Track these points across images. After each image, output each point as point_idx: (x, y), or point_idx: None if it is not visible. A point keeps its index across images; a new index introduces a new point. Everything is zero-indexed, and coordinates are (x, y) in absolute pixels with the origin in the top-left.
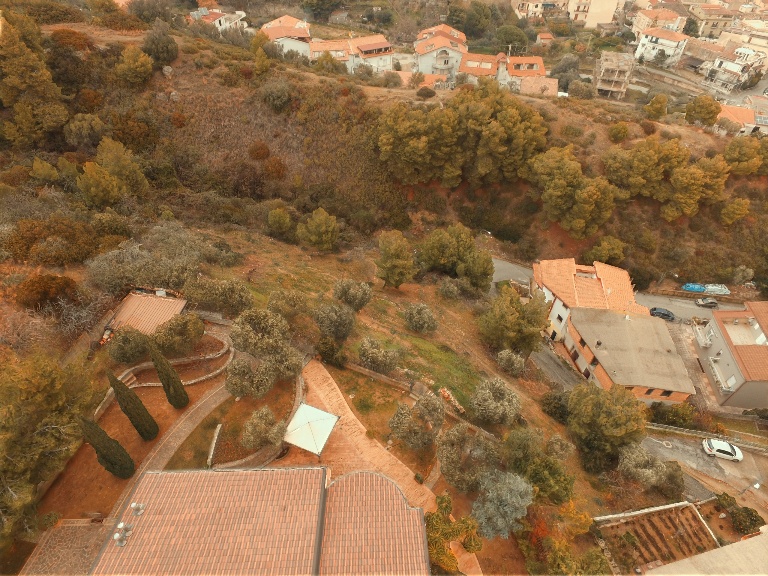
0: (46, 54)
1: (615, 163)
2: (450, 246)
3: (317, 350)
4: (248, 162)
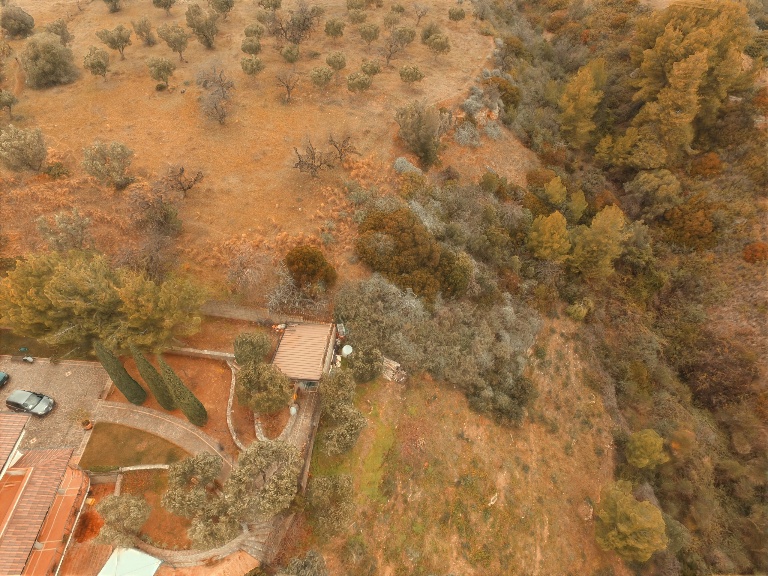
0: (732, 102)
1: None
2: None
3: None
4: (762, 365)
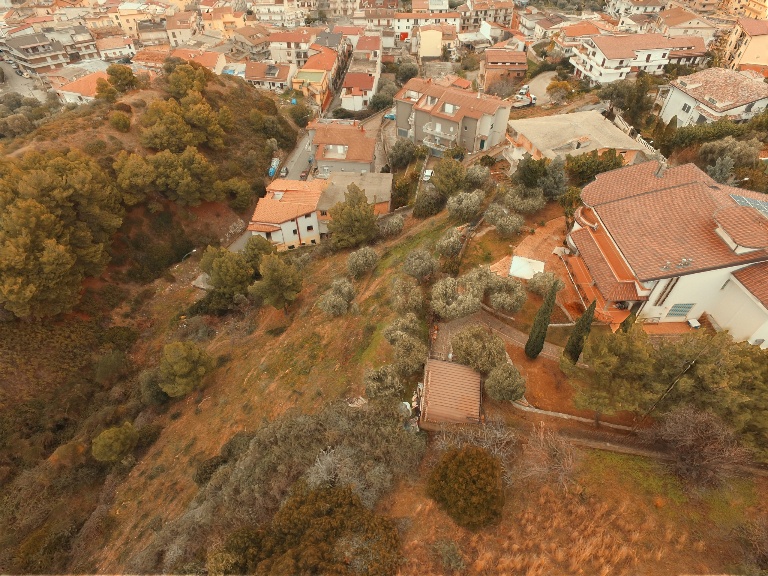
0: None
1: (161, 139)
2: (238, 259)
3: None
4: None
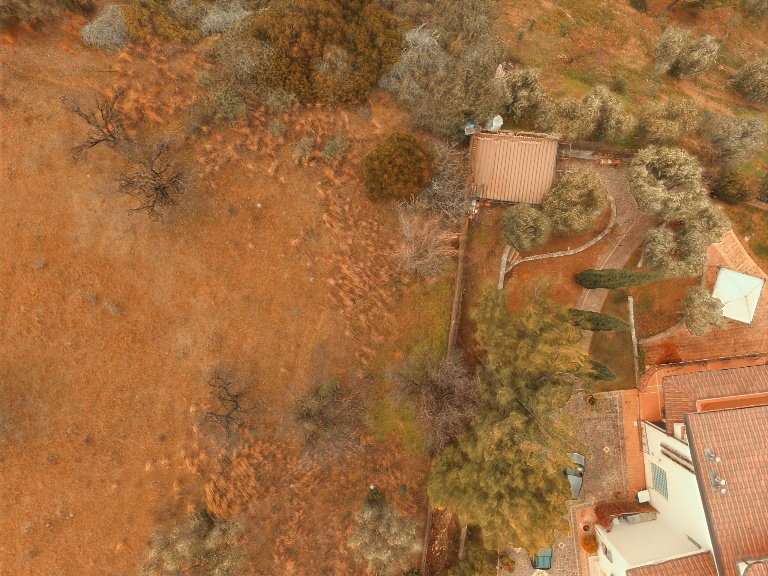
0: None
1: None
2: None
3: (716, 188)
4: None
